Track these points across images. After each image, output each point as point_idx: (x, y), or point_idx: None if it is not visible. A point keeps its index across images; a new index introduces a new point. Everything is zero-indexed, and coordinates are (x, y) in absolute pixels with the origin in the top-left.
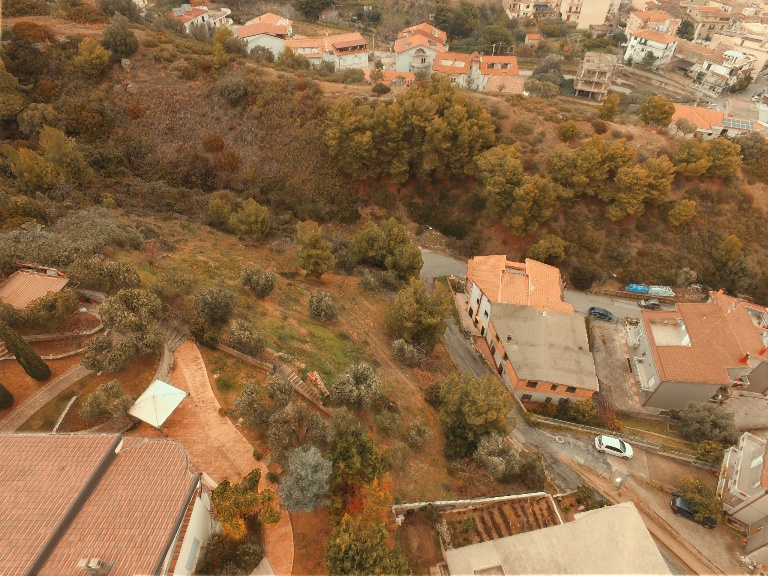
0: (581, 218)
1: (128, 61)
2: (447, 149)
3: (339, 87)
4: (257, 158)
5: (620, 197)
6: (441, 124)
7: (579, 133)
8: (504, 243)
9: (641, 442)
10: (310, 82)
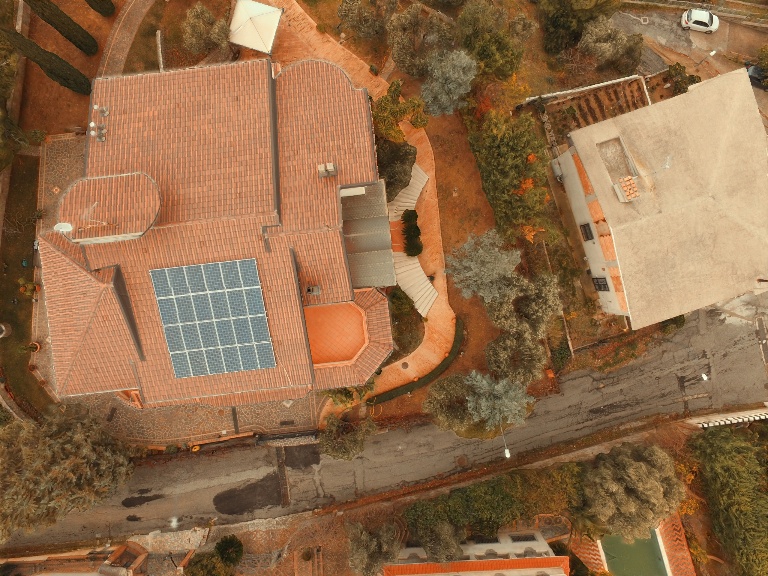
0: None
1: None
2: None
3: None
4: None
5: None
6: None
7: None
8: None
9: (730, 12)
10: None
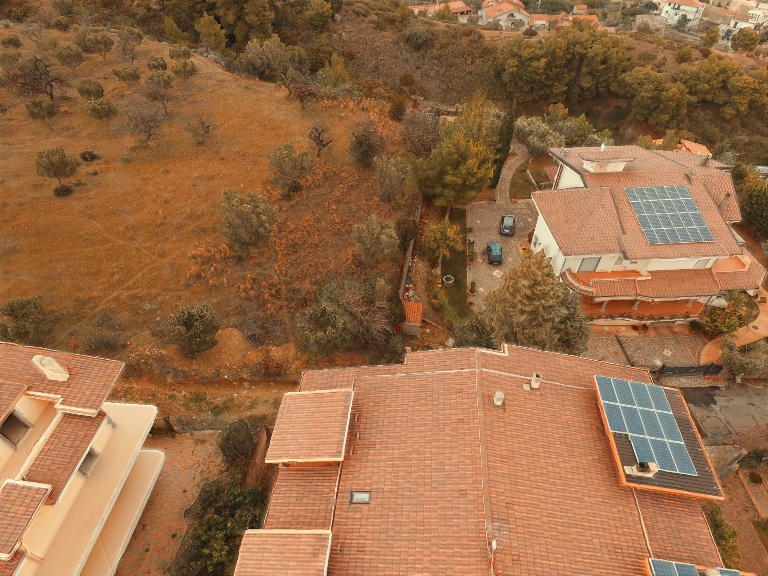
0: (700, 119)
1: (339, 15)
2: (598, 71)
3: (496, 33)
4: (440, 90)
5: (733, 99)
6: (600, 50)
7: (691, 57)
8: None
9: None
10: (474, 29)
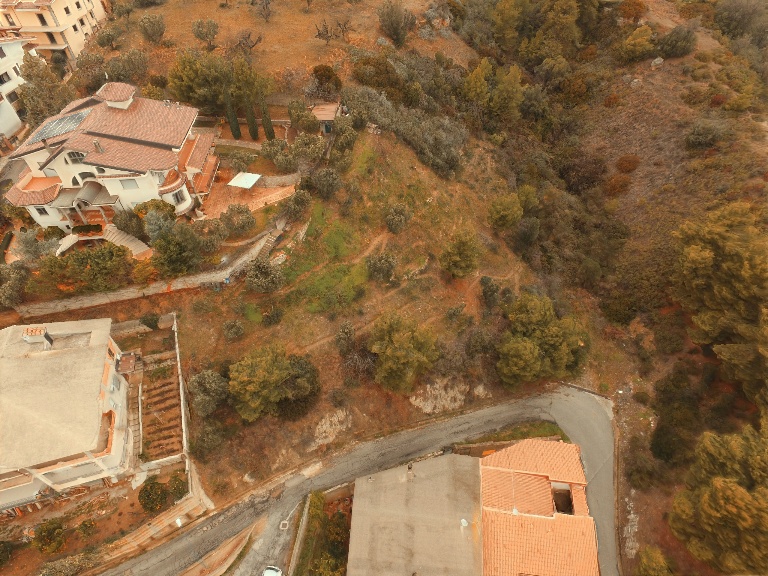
0: None
1: (661, 61)
2: None
3: None
4: None
5: None
6: None
7: None
8: (665, 516)
9: None
10: None
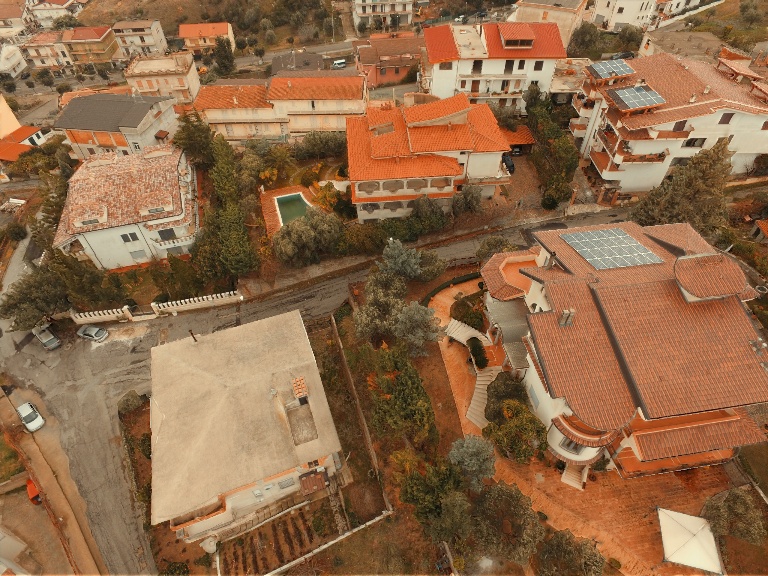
0: None
1: None
2: None
3: None
4: None
5: None
6: None
7: None
8: None
9: None
10: None
